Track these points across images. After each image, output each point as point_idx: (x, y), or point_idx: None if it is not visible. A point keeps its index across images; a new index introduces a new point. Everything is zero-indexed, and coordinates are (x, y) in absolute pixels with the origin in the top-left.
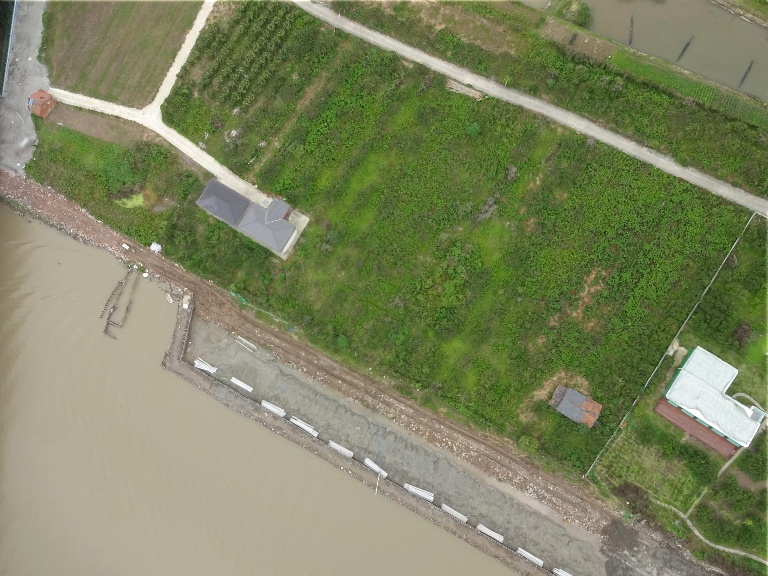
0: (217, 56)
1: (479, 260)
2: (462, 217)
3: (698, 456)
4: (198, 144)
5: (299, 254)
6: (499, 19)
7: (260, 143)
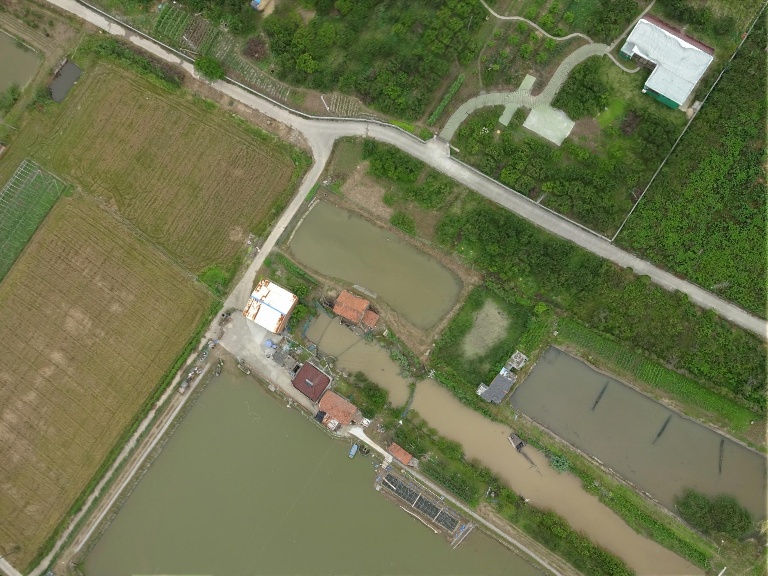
0: None
1: None
2: None
3: (681, 10)
4: None
5: None
6: None
7: None
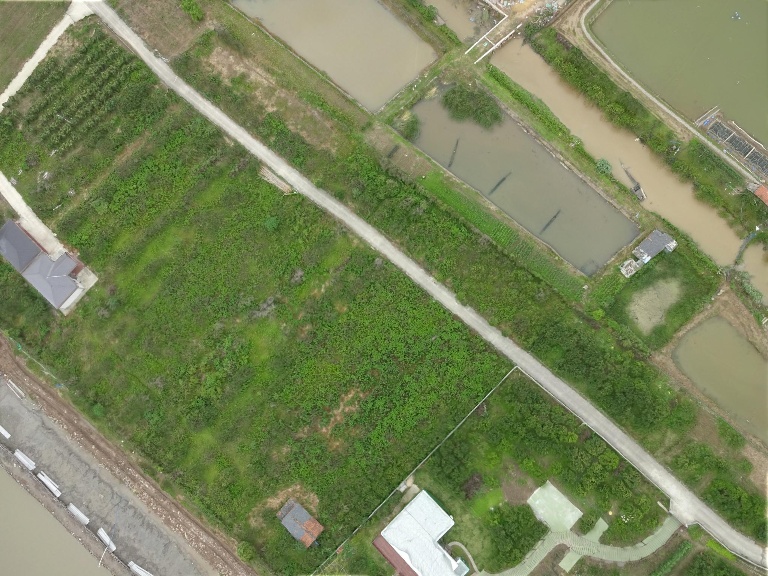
0: (49, 92)
1: (246, 357)
2: (241, 310)
3: None
4: (10, 179)
5: (79, 312)
6: (328, 114)
7: (69, 191)
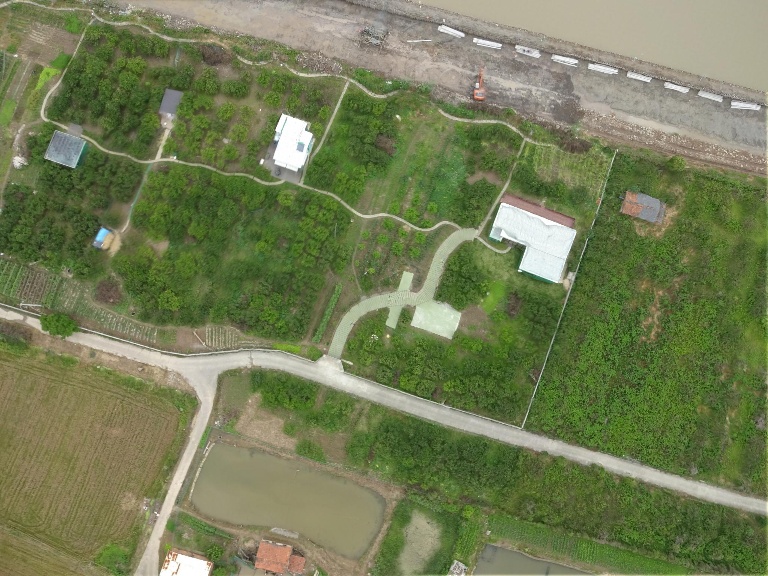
0: None
1: (765, 325)
2: None
3: (537, 187)
4: None
5: None
6: None
7: None
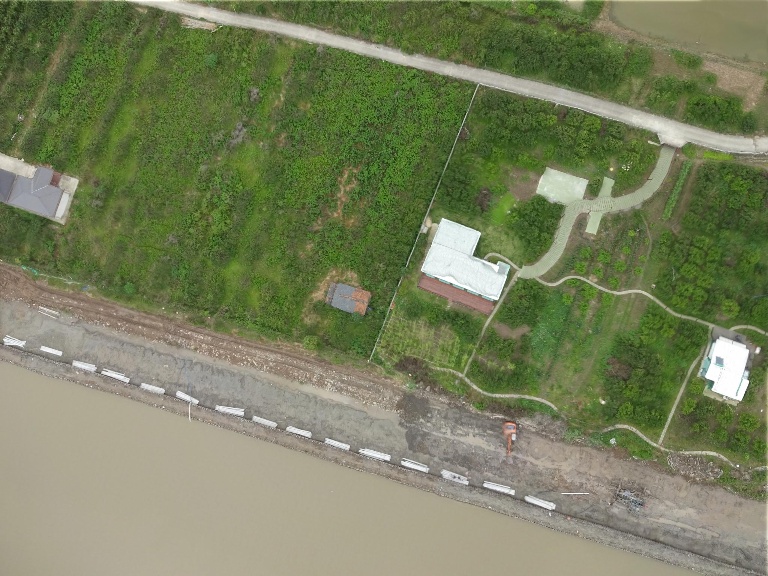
0: None
1: (240, 184)
2: (217, 147)
3: (459, 318)
4: None
5: (75, 216)
6: None
7: (18, 117)
